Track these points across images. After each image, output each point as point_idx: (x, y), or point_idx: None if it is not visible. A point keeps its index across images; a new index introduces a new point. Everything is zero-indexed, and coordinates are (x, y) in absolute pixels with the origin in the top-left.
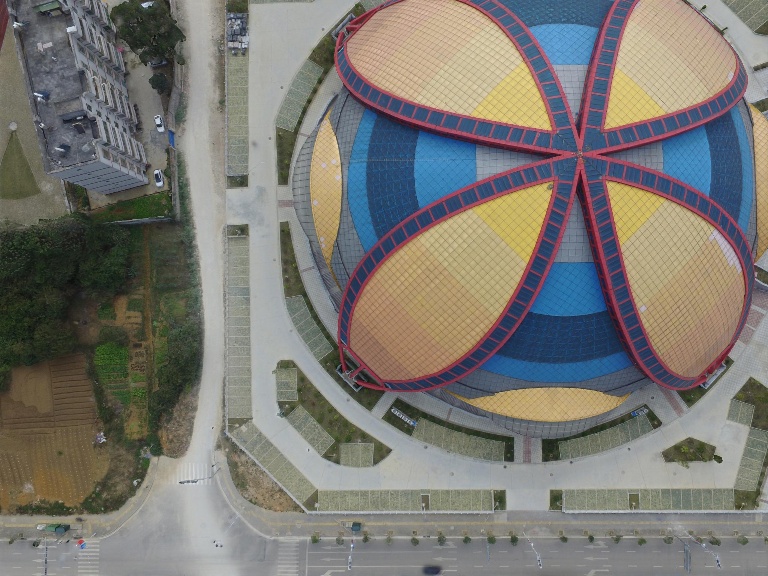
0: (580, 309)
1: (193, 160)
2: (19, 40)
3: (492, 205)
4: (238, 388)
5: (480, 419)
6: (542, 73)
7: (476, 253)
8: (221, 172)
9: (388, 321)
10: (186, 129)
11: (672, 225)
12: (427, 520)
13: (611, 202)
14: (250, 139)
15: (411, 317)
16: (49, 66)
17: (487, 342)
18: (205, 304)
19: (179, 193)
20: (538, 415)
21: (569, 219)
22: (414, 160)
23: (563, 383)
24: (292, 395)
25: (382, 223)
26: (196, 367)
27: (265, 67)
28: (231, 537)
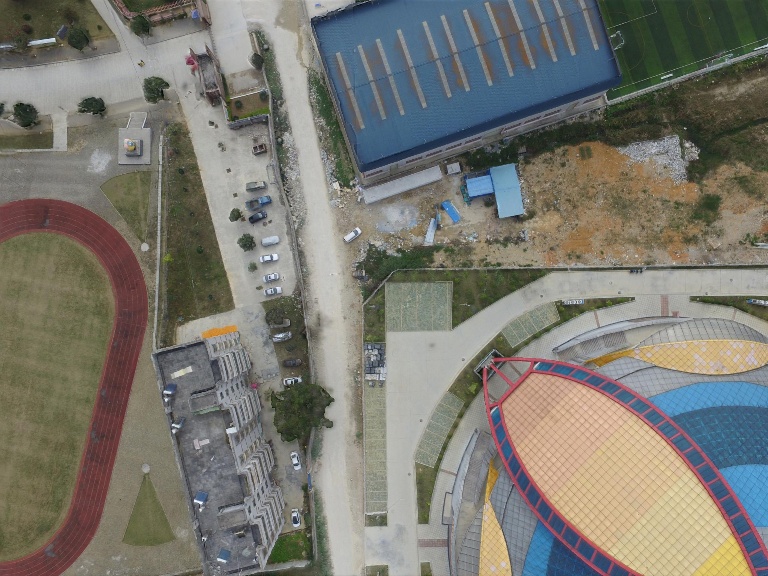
0: None
1: (330, 497)
2: (175, 438)
3: None
4: None
5: None
6: (755, 555)
7: None
8: (359, 509)
9: None
10: (322, 464)
11: None
12: None
13: None
14: (389, 474)
15: None
16: (206, 465)
17: None
18: None
19: (316, 532)
20: None
21: None
22: None
23: None
24: None
25: None
26: None
27: (403, 399)
28: None
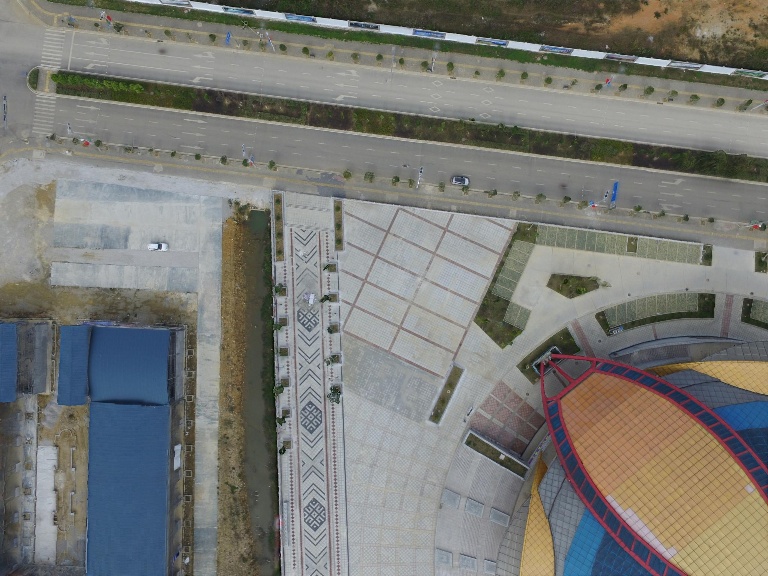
0: None
1: None
2: None
3: None
4: None
5: None
6: None
7: None
8: None
9: None
10: None
11: None
12: None
13: None
14: None
15: None
16: None
17: None
18: None
19: None
20: None
21: None
22: None
23: None
24: None
25: None
26: None
27: None
28: None
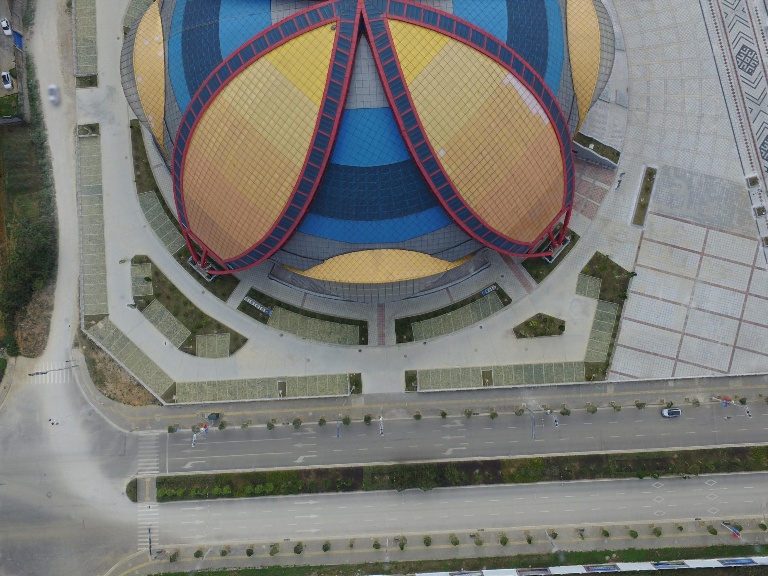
0: (383, 158)
1: (42, 62)
2: None
3: (282, 51)
4: (93, 285)
5: (334, 305)
6: None
7: (272, 102)
8: (70, 73)
9: (210, 189)
10: (34, 32)
11: (460, 65)
12: (285, 407)
13: (394, 40)
14: (99, 40)
15: (227, 180)
16: None
17: (297, 197)
18: (59, 204)
19: (29, 95)
20: (364, 277)
21: (360, 63)
22: (218, 21)
23: (386, 244)
24: (147, 290)
25: (197, 90)
26: (50, 266)
27: None
28: (91, 434)
